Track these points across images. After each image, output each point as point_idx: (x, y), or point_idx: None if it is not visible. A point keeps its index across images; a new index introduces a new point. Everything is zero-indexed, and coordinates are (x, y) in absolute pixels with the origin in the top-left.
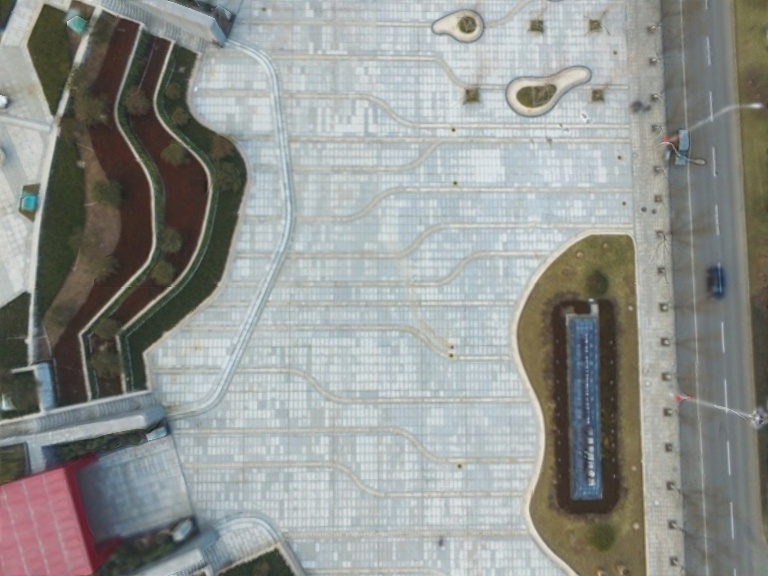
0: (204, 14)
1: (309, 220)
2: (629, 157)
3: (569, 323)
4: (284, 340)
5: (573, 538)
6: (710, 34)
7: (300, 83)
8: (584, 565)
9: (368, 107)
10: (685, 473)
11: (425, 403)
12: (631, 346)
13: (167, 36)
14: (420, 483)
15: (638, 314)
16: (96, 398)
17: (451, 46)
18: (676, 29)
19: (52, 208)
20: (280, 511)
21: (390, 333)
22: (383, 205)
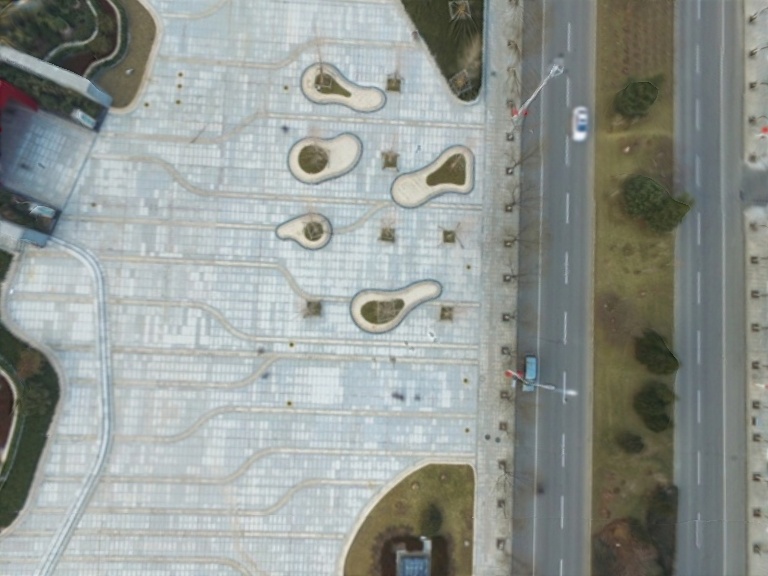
0: (12, 225)
1: (128, 440)
2: (476, 380)
3: (399, 561)
4: (92, 572)
5: None
6: (569, 250)
7: (128, 288)
8: None
9: (201, 316)
10: None
11: None
12: None
13: None
14: None
15: (474, 550)
16: None
17: (295, 252)
18: (534, 243)
19: None
20: None
21: (208, 566)
22: (210, 425)
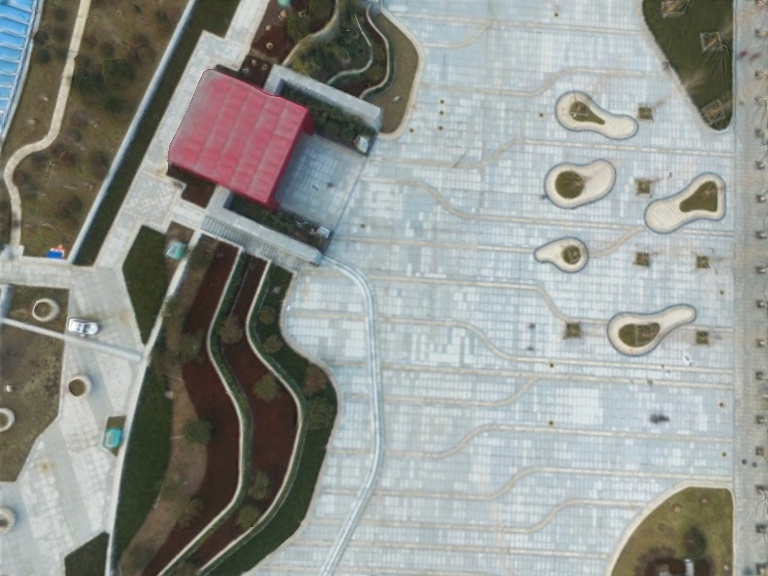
0: (308, 246)
1: (398, 454)
2: (731, 405)
3: None
4: None
5: None
6: None
7: (396, 306)
8: None
9: (465, 336)
10: None
11: None
12: None
13: (263, 254)
14: None
15: (734, 575)
16: None
17: (553, 275)
18: None
19: (137, 442)
20: None
21: None
22: (475, 443)
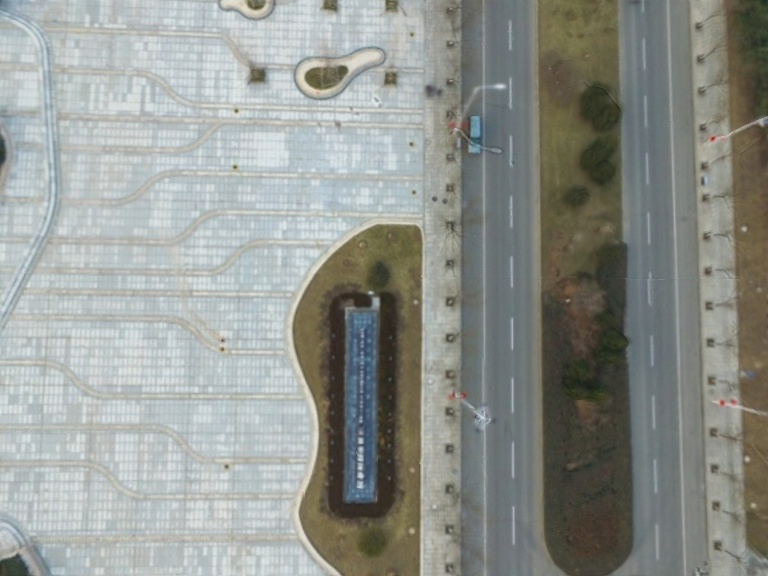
0: None
1: (75, 203)
2: (421, 144)
3: (348, 317)
4: (41, 330)
5: (343, 543)
6: (513, 18)
7: (73, 57)
8: (355, 572)
9: (146, 85)
10: (466, 476)
11: (192, 399)
12: (414, 342)
13: None
14: (183, 484)
15: (423, 308)
16: None
17: (238, 23)
18: (477, 12)
19: None
20: (29, 513)
21: (157, 324)
22: (156, 189)
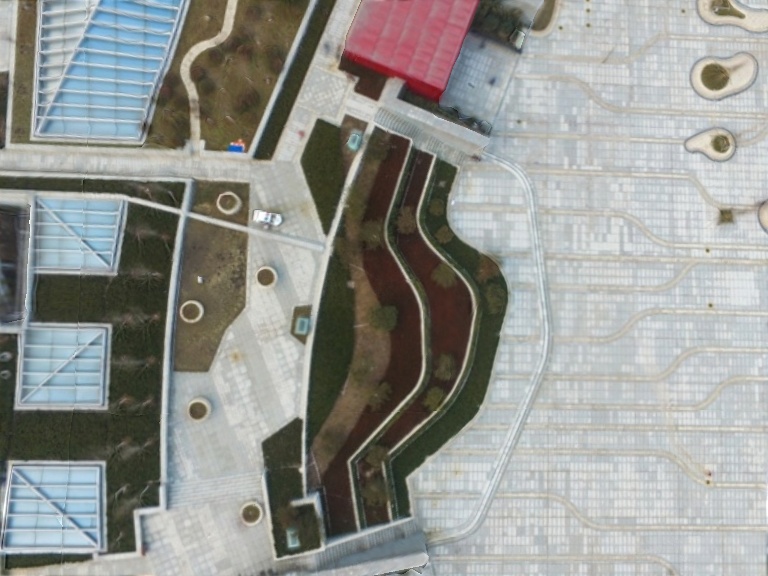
0: (480, 134)
1: (566, 340)
2: None
3: None
4: (542, 464)
5: None
6: None
7: (555, 198)
8: None
9: (623, 225)
10: None
11: (682, 531)
12: None
13: (428, 149)
14: None
15: None
16: (365, 527)
17: (704, 164)
18: None
19: (323, 330)
20: None
21: (647, 458)
22: (639, 326)
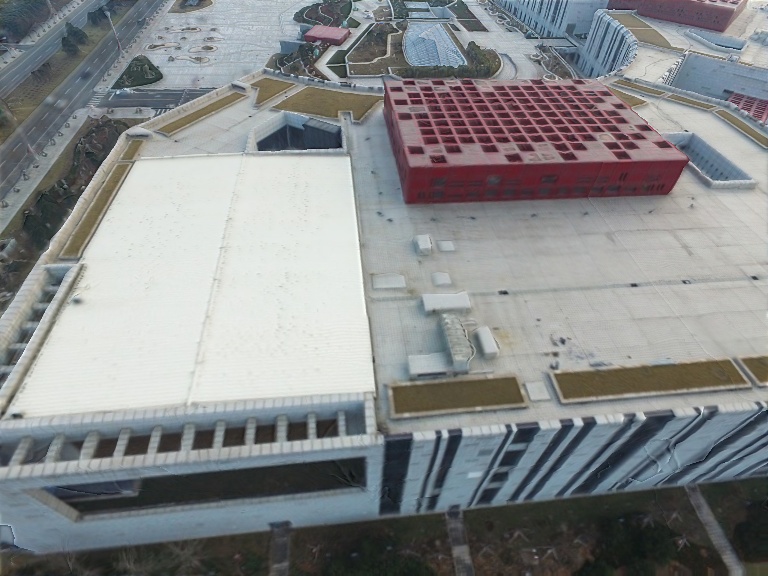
0: (303, 26)
1: None
2: None
3: (195, 4)
4: (284, 5)
5: None
6: None
7: (275, 32)
8: None
9: None
10: None
11: None
12: None
13: None
14: None
15: None
16: None
17: None
18: None
19: None
20: None
21: None
22: None
